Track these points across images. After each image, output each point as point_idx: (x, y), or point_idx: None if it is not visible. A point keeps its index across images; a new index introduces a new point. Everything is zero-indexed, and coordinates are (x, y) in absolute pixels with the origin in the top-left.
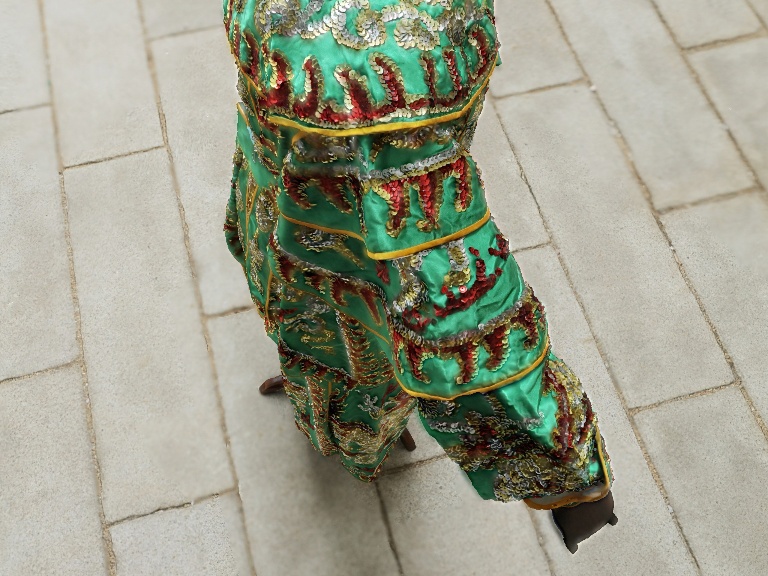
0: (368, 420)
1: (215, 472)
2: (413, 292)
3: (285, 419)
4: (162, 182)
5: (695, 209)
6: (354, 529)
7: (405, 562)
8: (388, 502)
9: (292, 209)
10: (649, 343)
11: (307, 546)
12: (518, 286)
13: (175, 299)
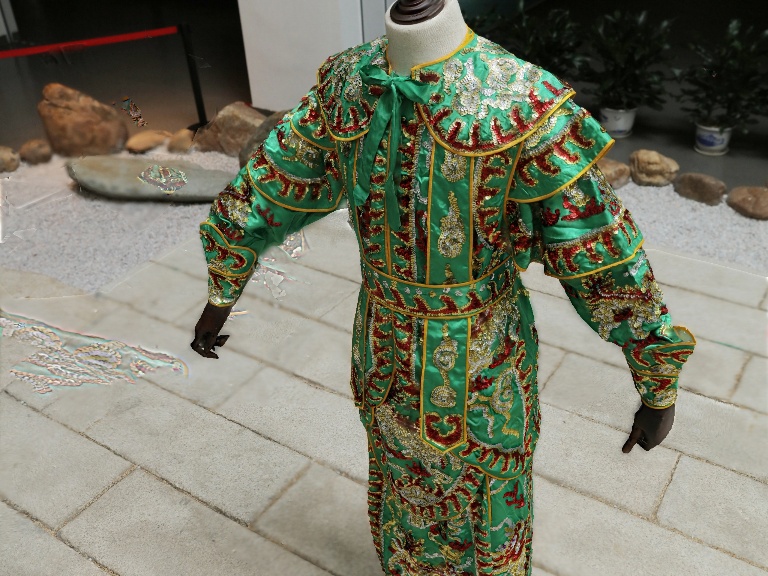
0: None
1: None
2: None
3: None
4: None
5: None
6: (380, 570)
7: None
8: None
9: None
10: None
11: None
12: (268, 143)
13: None
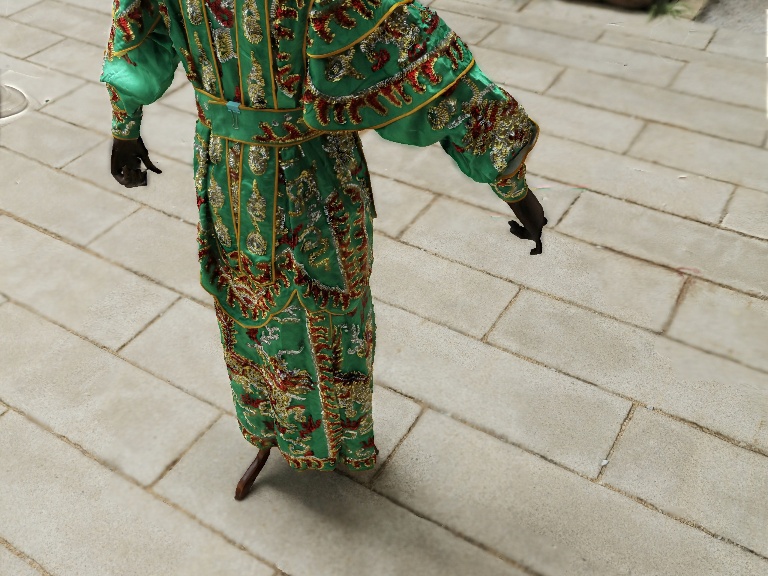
0: (358, 365)
1: (252, 573)
2: (407, 40)
3: (273, 502)
4: (29, 431)
5: (416, 224)
6: (385, 526)
7: (437, 517)
8: (392, 493)
9: (323, 47)
10: (458, 301)
11: (364, 562)
12: None
13: (112, 493)
